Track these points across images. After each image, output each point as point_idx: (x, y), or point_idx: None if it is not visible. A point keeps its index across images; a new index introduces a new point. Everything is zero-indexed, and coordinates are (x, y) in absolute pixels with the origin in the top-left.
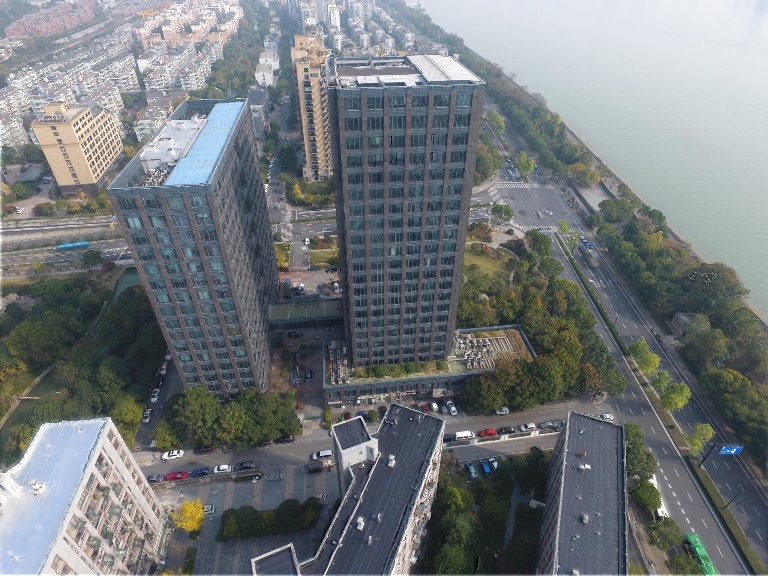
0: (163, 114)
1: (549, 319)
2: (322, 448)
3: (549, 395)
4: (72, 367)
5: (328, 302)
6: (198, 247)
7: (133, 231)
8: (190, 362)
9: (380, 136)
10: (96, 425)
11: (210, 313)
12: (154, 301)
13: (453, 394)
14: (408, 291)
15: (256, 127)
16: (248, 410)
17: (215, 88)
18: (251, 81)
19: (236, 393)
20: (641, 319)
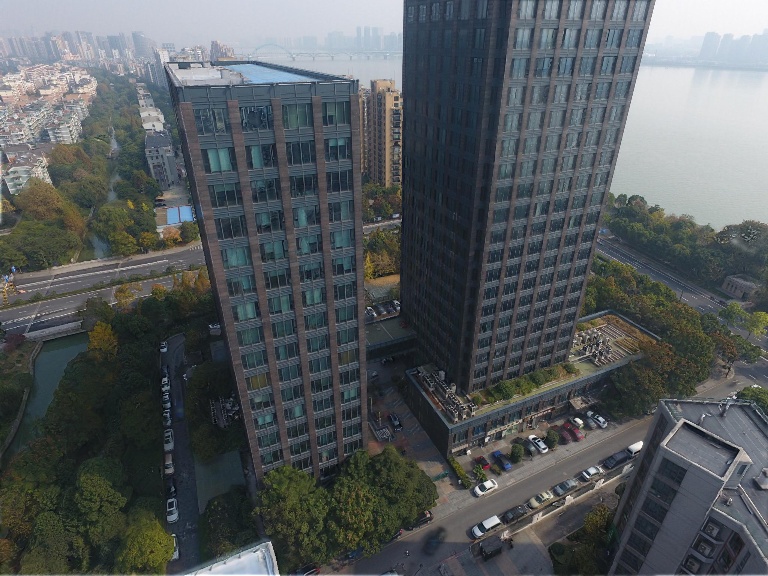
0: (42, 161)
1: (641, 297)
2: (477, 517)
3: (703, 375)
4: (17, 495)
5: (385, 323)
6: (320, 204)
7: (215, 177)
8: (272, 426)
9: (553, 28)
10: (245, 568)
11: (318, 329)
12: (231, 318)
13: (596, 400)
14: (544, 268)
15: (170, 168)
16: (372, 485)
17: (96, 140)
18: (141, 130)
19: (332, 466)
20: (693, 290)
